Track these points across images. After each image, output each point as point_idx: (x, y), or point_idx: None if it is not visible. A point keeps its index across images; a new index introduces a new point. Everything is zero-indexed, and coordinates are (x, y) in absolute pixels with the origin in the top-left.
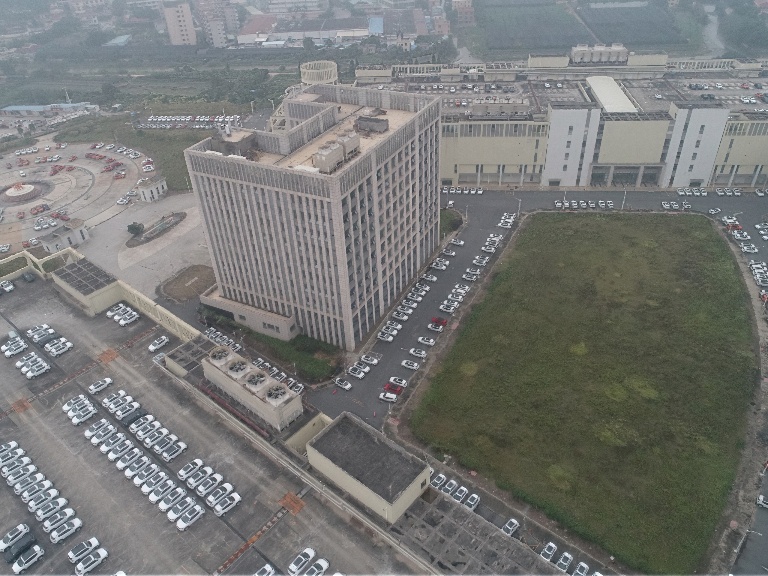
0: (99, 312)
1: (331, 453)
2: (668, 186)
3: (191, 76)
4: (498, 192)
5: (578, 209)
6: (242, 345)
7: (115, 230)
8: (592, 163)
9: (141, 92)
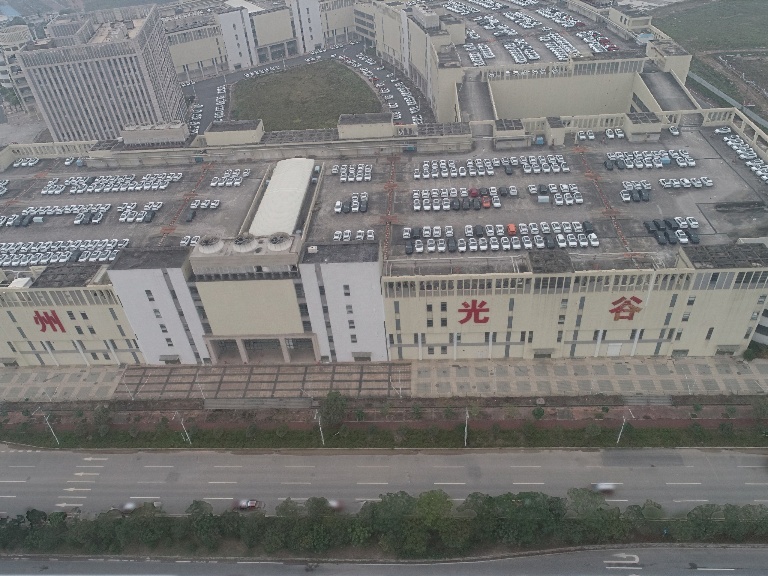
0: (5, 168)
1: None
2: (304, 52)
3: None
4: (205, 81)
5: (260, 75)
6: None
7: None
8: (255, 47)
9: None
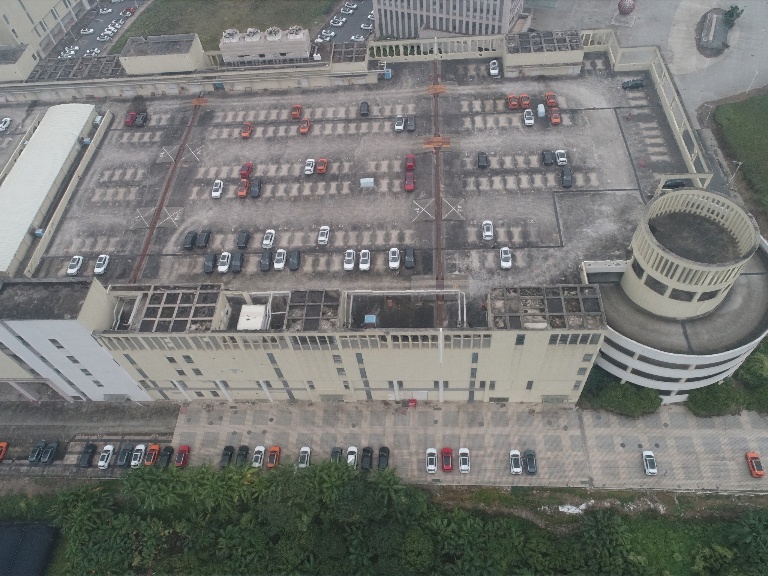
0: None
1: None
2: None
3: None
4: None
5: None
6: None
7: None
8: None
9: None
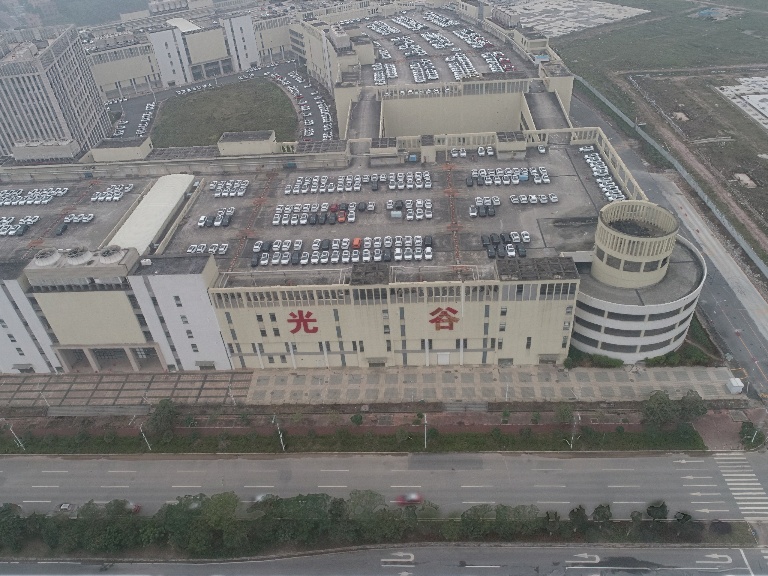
0: None
1: None
2: (239, 70)
3: None
4: (137, 98)
5: (192, 92)
6: None
7: None
8: (189, 65)
9: None
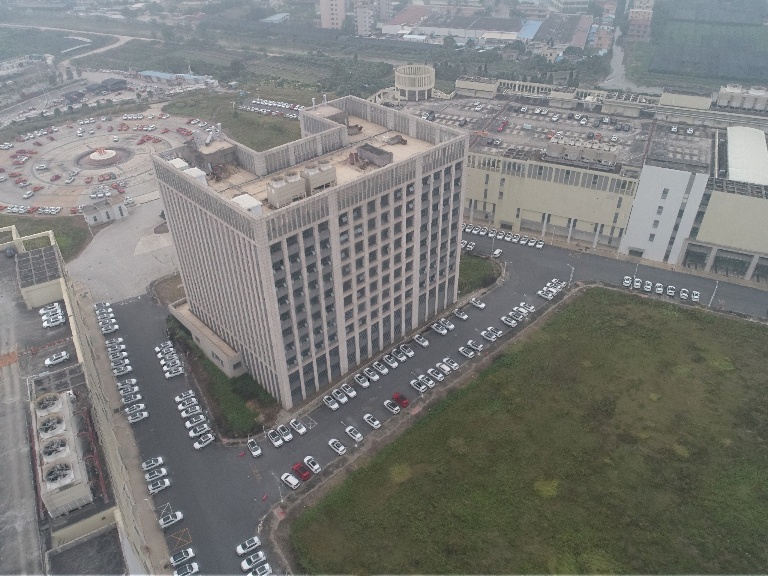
0: (37, 306)
1: (66, 574)
2: None
3: (319, 62)
4: (562, 250)
5: (650, 293)
6: (187, 369)
7: (155, 212)
8: (688, 239)
9: (265, 72)
